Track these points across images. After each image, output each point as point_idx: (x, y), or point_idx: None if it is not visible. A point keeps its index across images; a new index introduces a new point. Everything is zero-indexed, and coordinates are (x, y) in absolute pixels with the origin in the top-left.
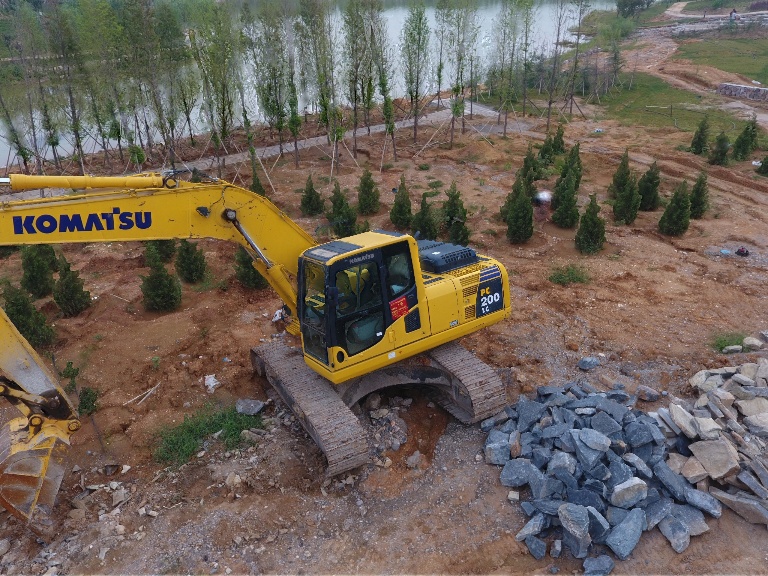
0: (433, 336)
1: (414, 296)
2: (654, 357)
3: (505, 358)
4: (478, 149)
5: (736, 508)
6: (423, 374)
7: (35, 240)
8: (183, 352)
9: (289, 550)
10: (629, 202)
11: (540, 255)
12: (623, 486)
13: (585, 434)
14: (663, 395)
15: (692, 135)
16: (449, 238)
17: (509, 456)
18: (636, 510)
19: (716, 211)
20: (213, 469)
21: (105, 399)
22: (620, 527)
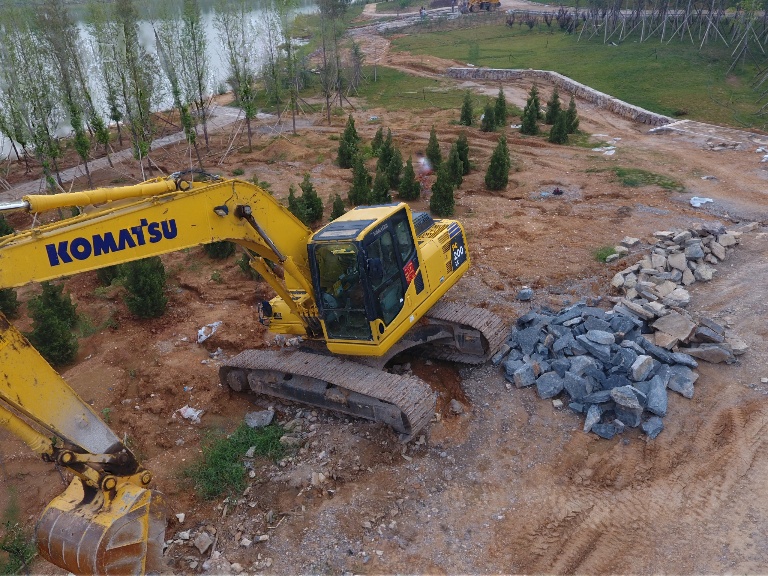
0: (432, 294)
1: (416, 259)
2: (564, 278)
3: None
4: (282, 147)
5: (704, 356)
6: (424, 334)
7: (72, 270)
8: (124, 398)
9: (418, 514)
10: (455, 169)
11: None
12: (638, 364)
13: (593, 335)
14: (600, 300)
15: (453, 111)
16: (315, 229)
17: (534, 375)
18: (656, 377)
19: (515, 166)
20: (287, 478)
21: None
22: (653, 393)
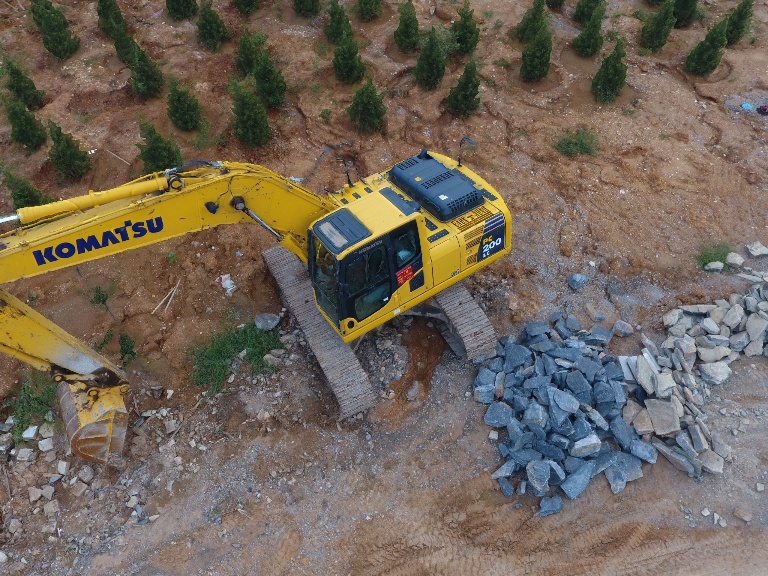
0: (435, 287)
1: (419, 262)
2: (640, 271)
3: (501, 265)
4: None
5: (669, 458)
6: (424, 309)
7: (58, 265)
8: (195, 238)
9: (314, 482)
10: (661, 26)
11: (552, 103)
12: (582, 444)
13: (559, 397)
14: (637, 330)
15: None
16: (458, 67)
17: None
18: (588, 465)
19: (755, 33)
20: (245, 402)
21: (133, 301)
22: (573, 478)
